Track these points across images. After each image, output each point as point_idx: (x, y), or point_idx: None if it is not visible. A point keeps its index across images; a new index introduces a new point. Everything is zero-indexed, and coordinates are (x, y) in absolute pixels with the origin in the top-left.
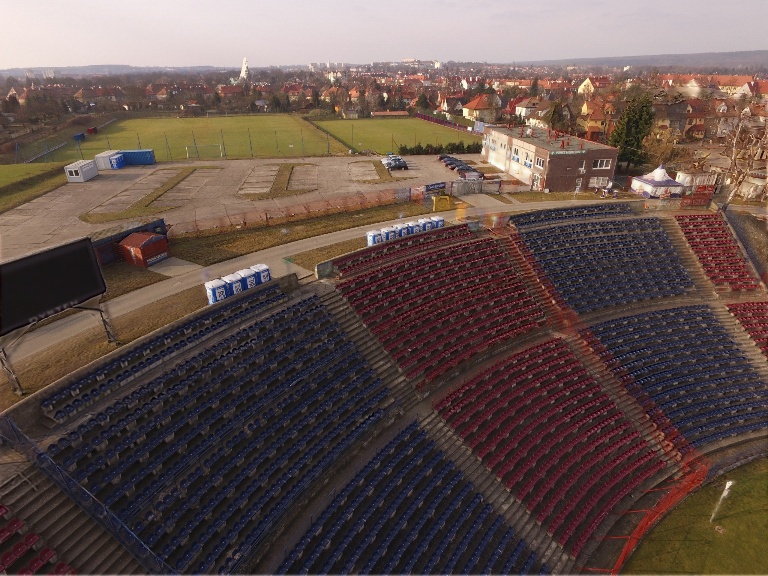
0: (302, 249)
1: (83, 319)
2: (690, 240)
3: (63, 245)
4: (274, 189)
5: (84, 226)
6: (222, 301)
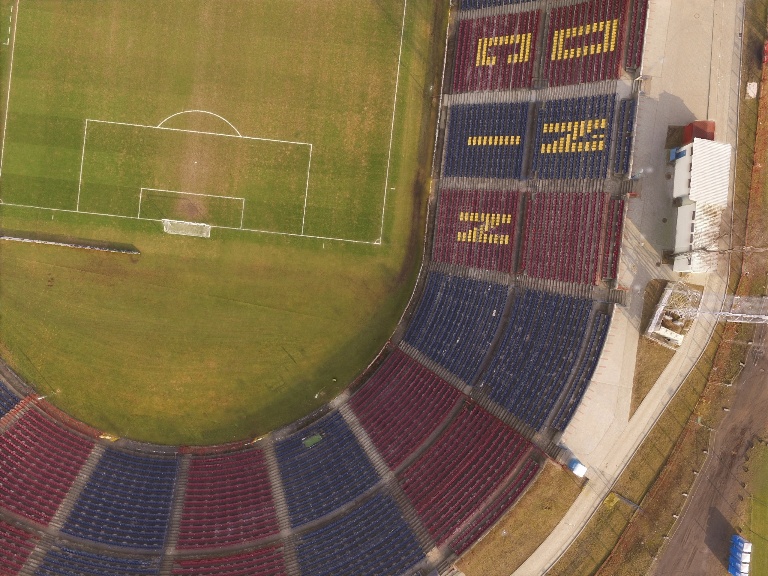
0: None
1: None
2: None
3: None
4: None
5: None
6: None
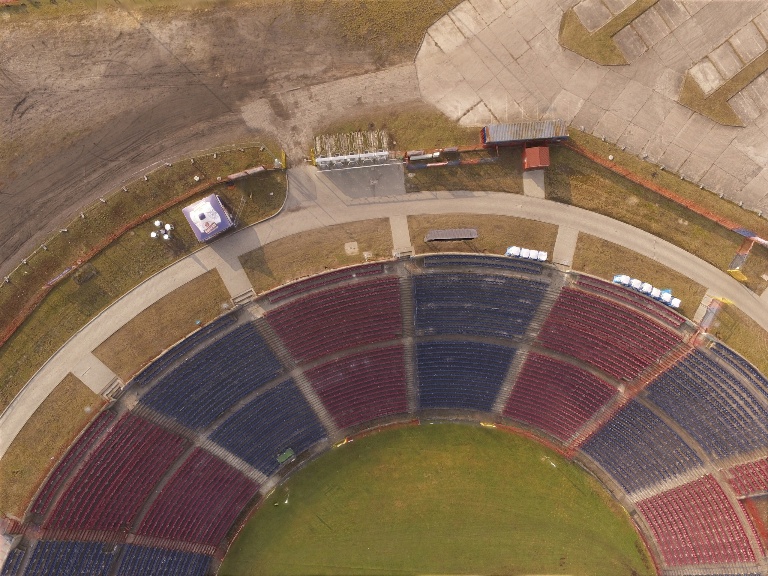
0: (599, 232)
1: (469, 201)
2: None
3: None
4: (719, 92)
5: (552, 46)
6: None
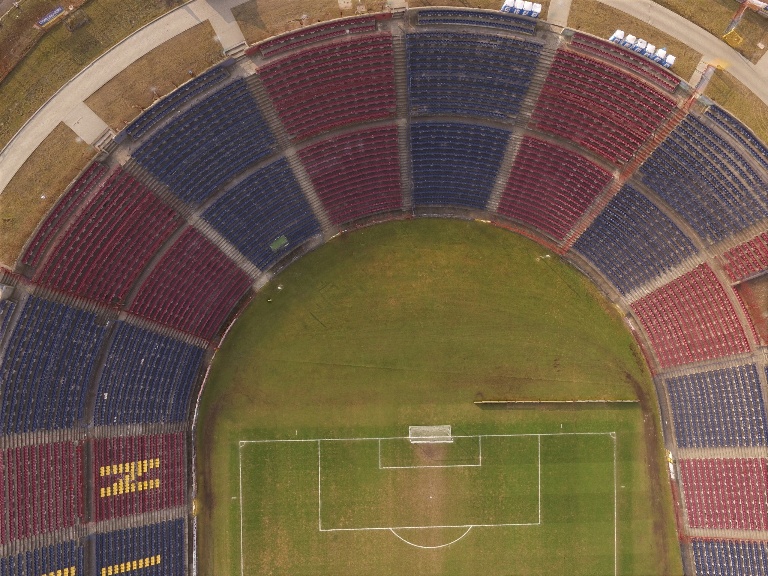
0: None
1: None
2: (767, 234)
3: None
4: None
5: None
6: (505, 13)
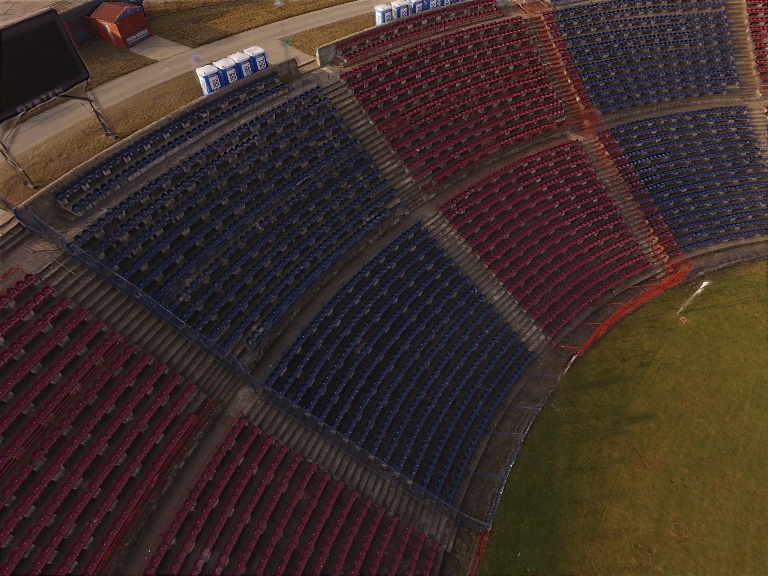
0: (300, 28)
1: (73, 109)
2: (753, 24)
3: (27, 18)
4: None
5: None
6: (217, 91)
